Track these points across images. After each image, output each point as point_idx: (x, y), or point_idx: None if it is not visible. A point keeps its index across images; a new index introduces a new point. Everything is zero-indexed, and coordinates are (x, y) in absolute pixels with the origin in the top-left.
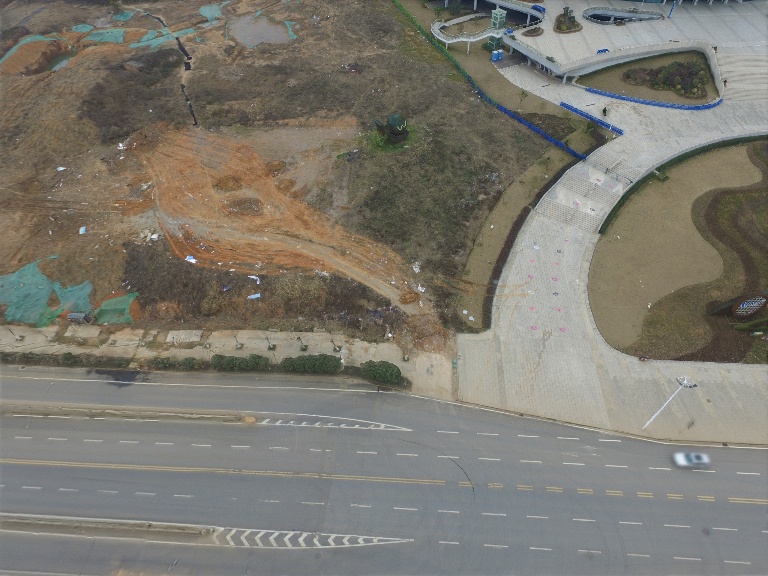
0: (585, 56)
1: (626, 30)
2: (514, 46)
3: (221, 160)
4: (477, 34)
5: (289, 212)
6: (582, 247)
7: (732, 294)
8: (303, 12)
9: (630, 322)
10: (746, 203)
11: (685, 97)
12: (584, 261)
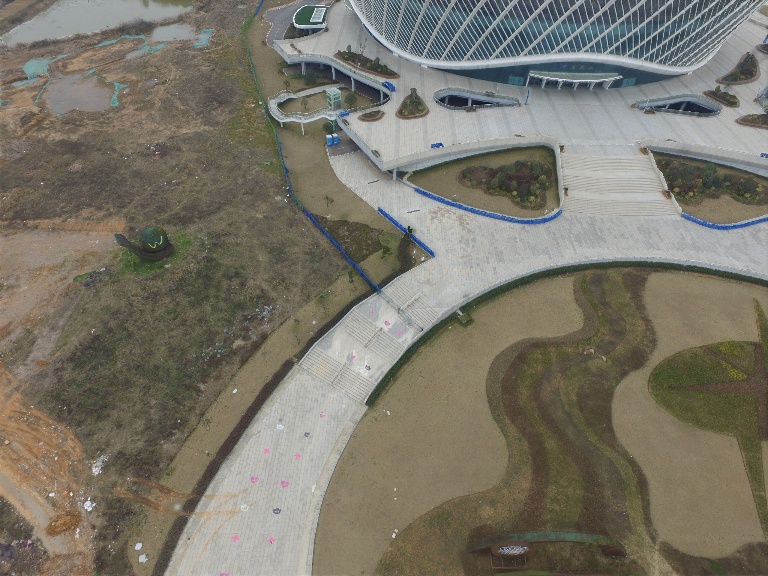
0: (416, 150)
1: (475, 118)
2: (346, 132)
3: None
4: (310, 114)
5: None
6: (339, 428)
7: (508, 513)
8: (141, 73)
9: (360, 565)
10: (556, 362)
11: (520, 206)
12: (333, 452)
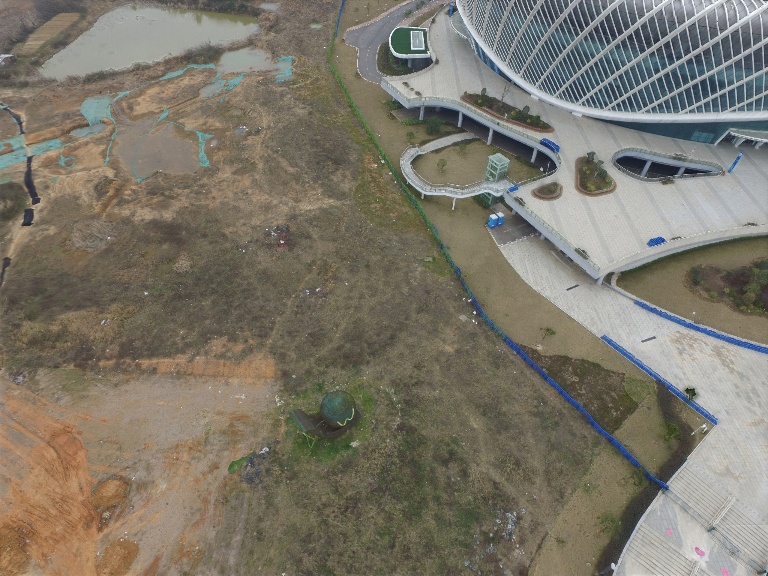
0: (631, 248)
1: (678, 194)
2: (522, 214)
3: (11, 471)
4: (467, 187)
5: None
6: None
7: None
8: (226, 118)
9: None
10: None
11: None
12: None
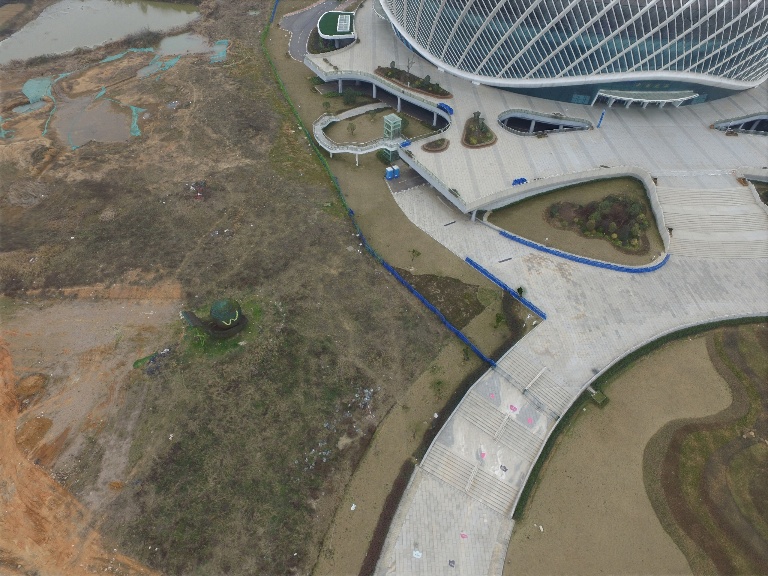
0: (498, 188)
1: (549, 145)
2: (411, 165)
3: None
4: (366, 144)
5: (18, 499)
6: (487, 552)
7: None
8: (159, 94)
9: None
10: (715, 450)
11: (623, 251)
12: None
